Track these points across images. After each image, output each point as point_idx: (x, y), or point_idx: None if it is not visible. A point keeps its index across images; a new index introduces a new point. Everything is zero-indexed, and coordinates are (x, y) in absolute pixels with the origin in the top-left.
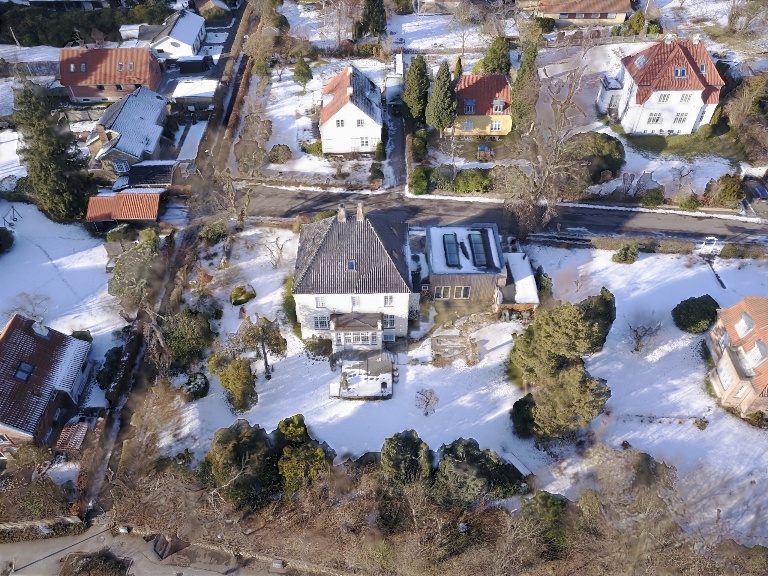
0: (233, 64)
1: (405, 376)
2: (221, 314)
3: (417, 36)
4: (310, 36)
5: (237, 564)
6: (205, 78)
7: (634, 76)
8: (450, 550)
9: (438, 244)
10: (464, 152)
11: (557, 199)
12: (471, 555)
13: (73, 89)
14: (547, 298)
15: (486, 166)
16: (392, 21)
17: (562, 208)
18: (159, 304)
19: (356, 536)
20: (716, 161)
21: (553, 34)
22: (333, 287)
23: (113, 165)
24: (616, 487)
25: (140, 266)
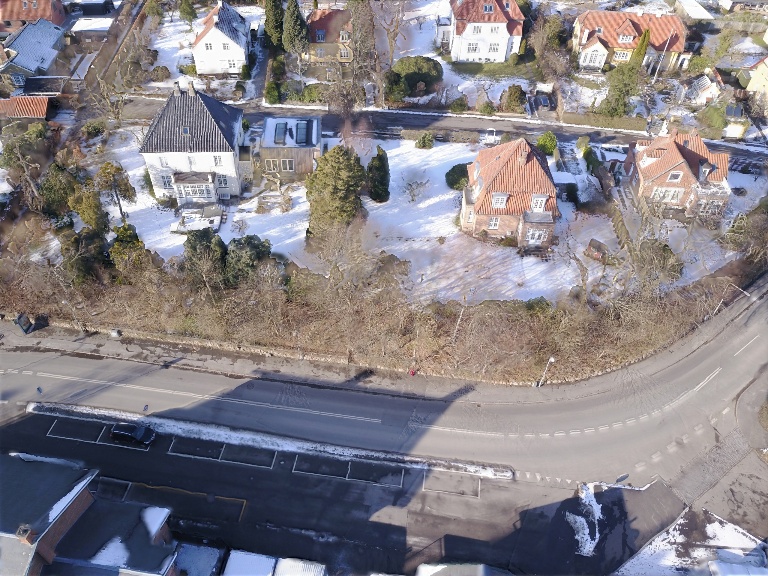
0: (130, 7)
1: (232, 219)
2: None
3: None
4: None
5: (84, 336)
6: None
7: (455, 12)
8: (242, 318)
9: (271, 129)
10: (317, 74)
11: (384, 107)
12: (257, 321)
13: None
14: None
15: None
16: None
17: (387, 114)
18: None
19: (157, 287)
20: (518, 81)
21: None
22: (172, 147)
23: (11, 79)
24: (366, 274)
25: (26, 147)
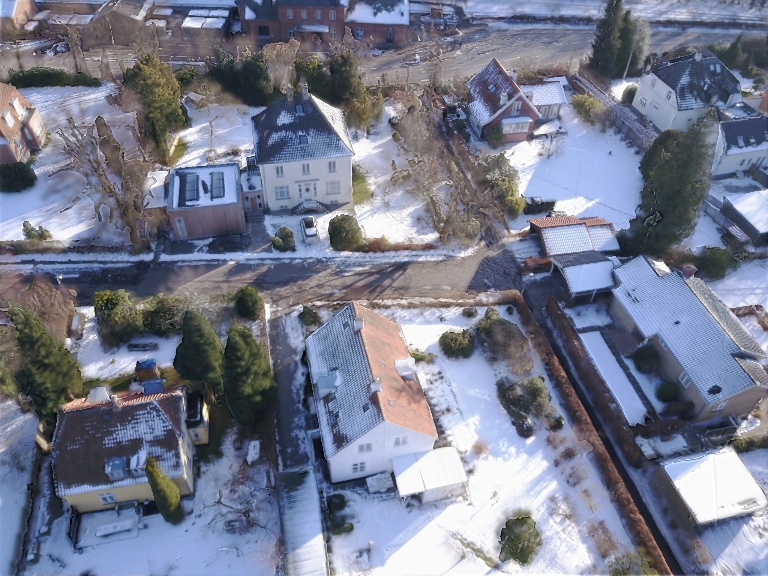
0: None
1: None
2: None
3: None
4: None
5: None
6: None
7: None
8: None
9: (230, 190)
10: (179, 385)
11: None
12: None
13: None
14: None
15: None
16: None
17: None
18: (469, 177)
19: None
20: None
21: None
22: None
23: None
24: None
25: None
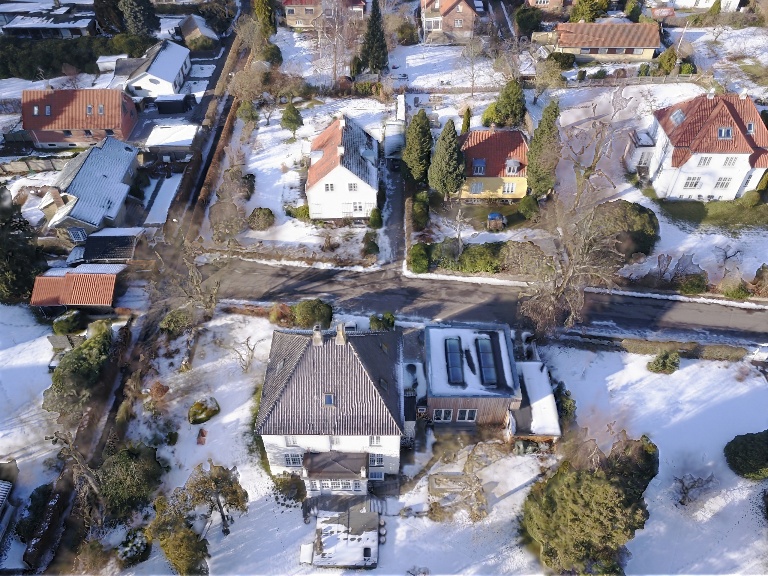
0: (217, 104)
1: (394, 534)
2: (176, 438)
3: (422, 71)
4: (304, 70)
5: None
6: (185, 120)
7: (670, 134)
8: None
9: (439, 352)
10: (472, 219)
11: None
12: None
13: (37, 134)
14: (570, 424)
15: (497, 237)
16: (395, 53)
17: (586, 294)
18: (105, 418)
19: None
20: (765, 236)
21: (573, 71)
22: (306, 427)
23: (69, 233)
24: None
25: (84, 373)
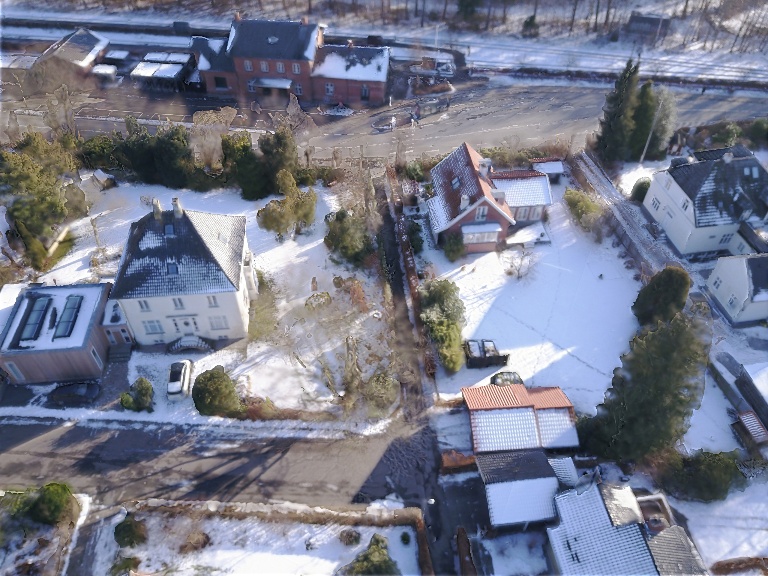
0: None
1: None
2: None
3: None
4: None
5: None
6: None
7: None
8: None
9: (81, 324)
10: None
11: None
12: None
13: None
14: None
15: None
16: None
17: None
18: (409, 304)
19: (206, 112)
20: None
21: None
22: None
23: None
24: None
25: None
